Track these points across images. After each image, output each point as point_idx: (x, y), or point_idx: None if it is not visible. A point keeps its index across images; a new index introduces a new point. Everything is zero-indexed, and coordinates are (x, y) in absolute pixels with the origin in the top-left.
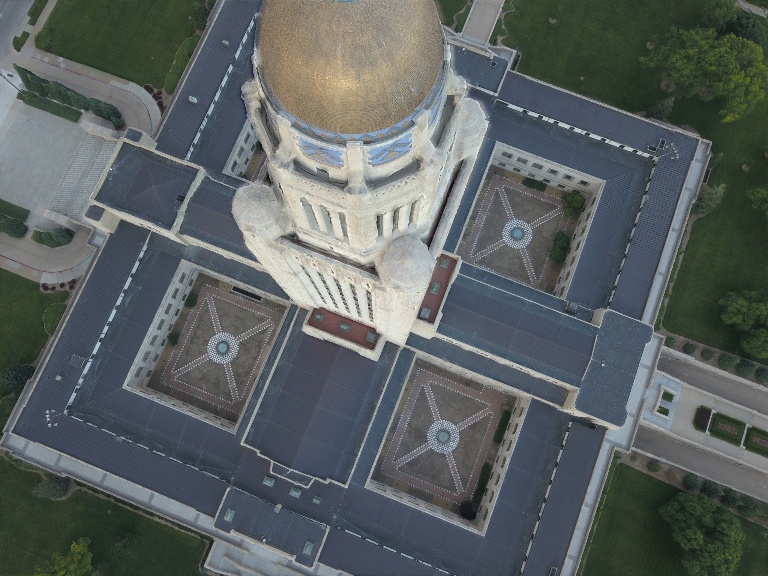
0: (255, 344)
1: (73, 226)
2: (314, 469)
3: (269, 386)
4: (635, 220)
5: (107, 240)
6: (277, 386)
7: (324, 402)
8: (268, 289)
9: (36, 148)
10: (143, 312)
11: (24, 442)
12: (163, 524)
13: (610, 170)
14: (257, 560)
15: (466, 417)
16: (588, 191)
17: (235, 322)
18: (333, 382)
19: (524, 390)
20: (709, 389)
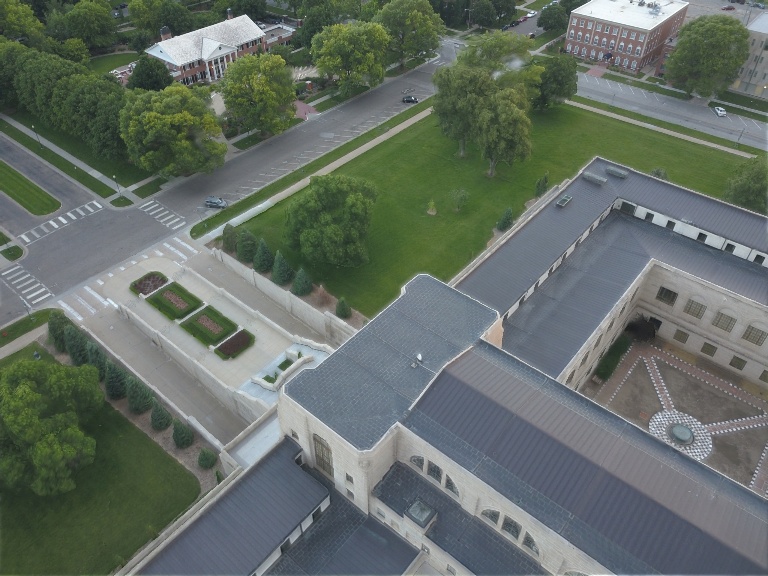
0: None
1: None
2: None
3: None
4: None
5: None
6: None
7: None
8: None
9: None
10: None
11: None
12: None
13: None
14: None
15: None
16: None
17: None
18: None
19: None
20: (190, 390)
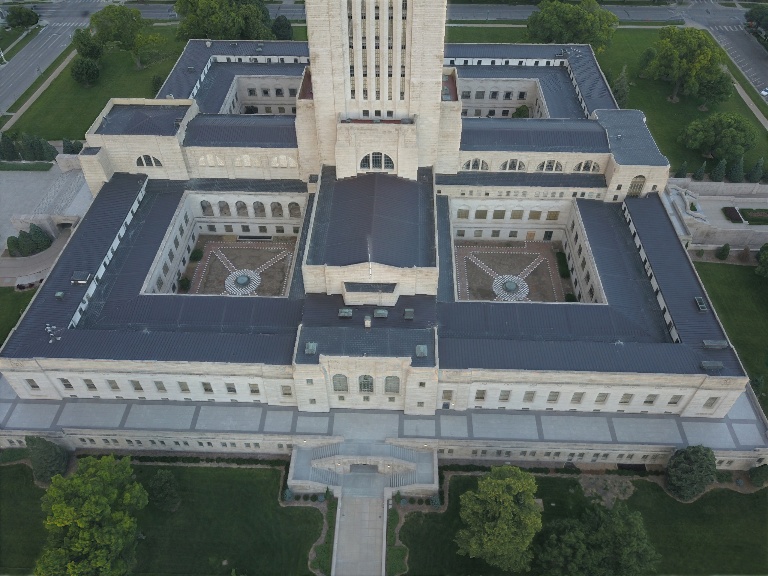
0: (277, 271)
1: (53, 229)
2: (395, 264)
3: (314, 224)
4: (576, 93)
5: (102, 187)
6: (323, 222)
7: (379, 211)
8: (281, 191)
9: (5, 194)
10: (151, 235)
11: (4, 415)
12: (214, 467)
13: (537, 75)
14: (358, 446)
15: (523, 268)
16: (528, 104)
17: (249, 260)
18: (381, 197)
19: (565, 186)
20: None
